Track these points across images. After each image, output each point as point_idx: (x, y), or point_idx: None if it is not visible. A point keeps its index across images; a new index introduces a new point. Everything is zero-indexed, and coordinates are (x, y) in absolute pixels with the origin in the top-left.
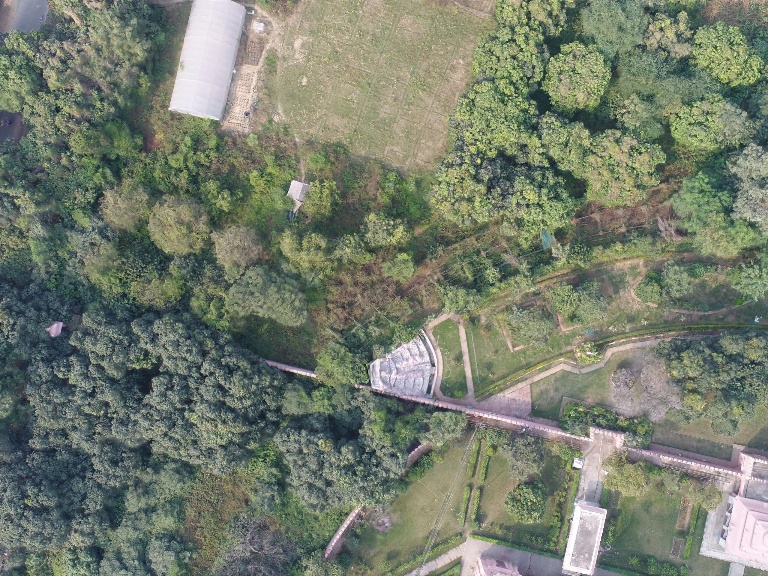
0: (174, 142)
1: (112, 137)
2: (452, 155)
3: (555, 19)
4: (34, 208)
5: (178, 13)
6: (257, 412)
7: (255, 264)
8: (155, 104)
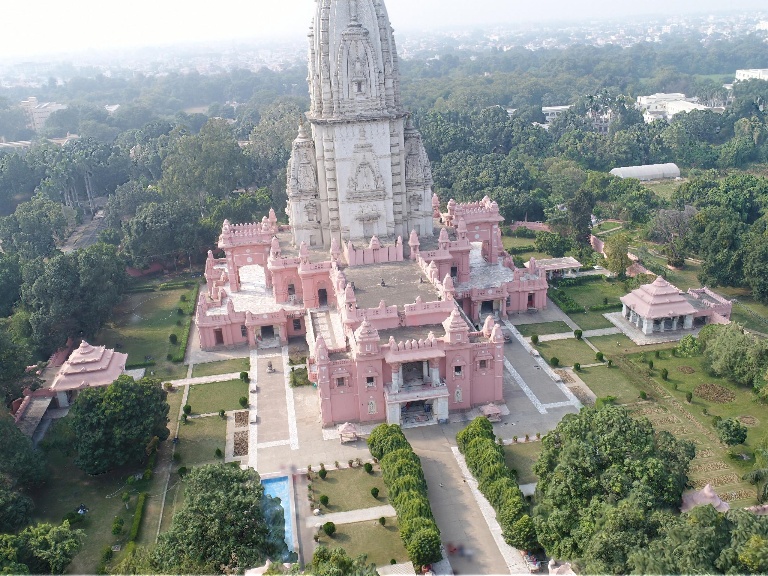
0: None
1: None
2: None
3: None
4: (532, 140)
5: None
6: None
7: None
8: None
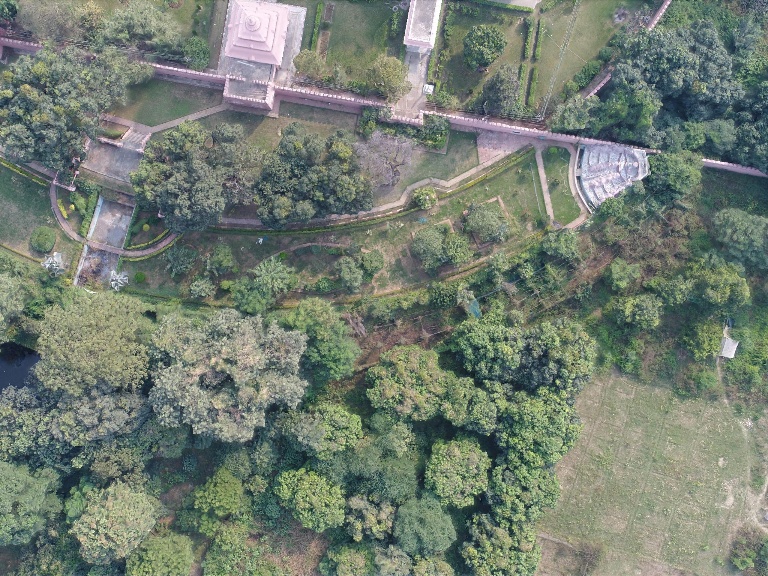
0: None
1: None
2: None
3: (483, 530)
4: None
5: None
6: (765, 118)
7: None
8: None
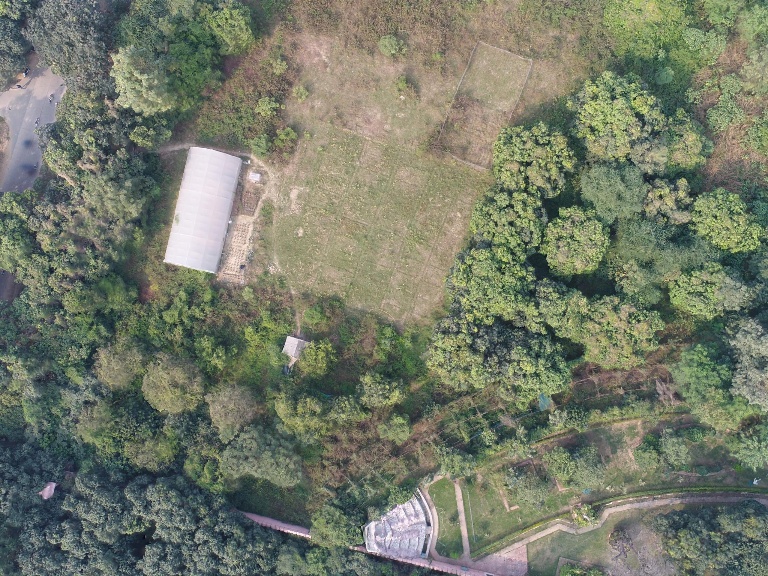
0: (169, 294)
1: (106, 292)
2: (449, 321)
3: (553, 182)
4: (27, 375)
5: (173, 161)
6: (251, 575)
7: (250, 424)
8: (150, 254)
